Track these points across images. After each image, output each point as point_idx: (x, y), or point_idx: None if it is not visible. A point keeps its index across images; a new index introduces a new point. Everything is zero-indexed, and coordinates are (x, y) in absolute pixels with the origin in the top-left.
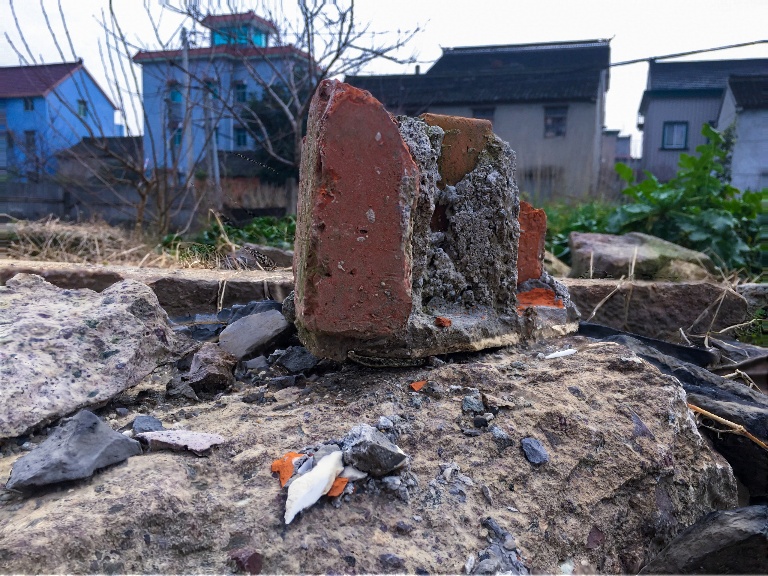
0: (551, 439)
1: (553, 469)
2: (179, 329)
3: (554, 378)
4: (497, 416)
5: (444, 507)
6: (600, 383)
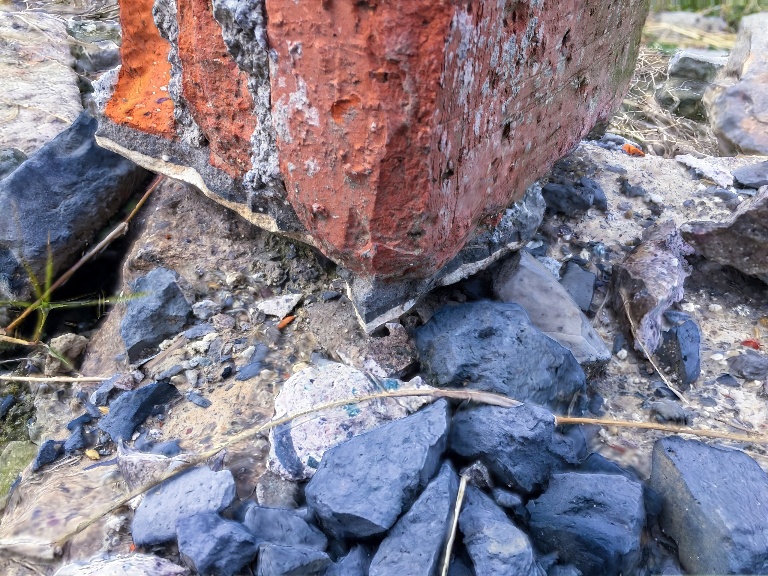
0: None
1: None
2: None
3: None
4: None
5: None
6: None
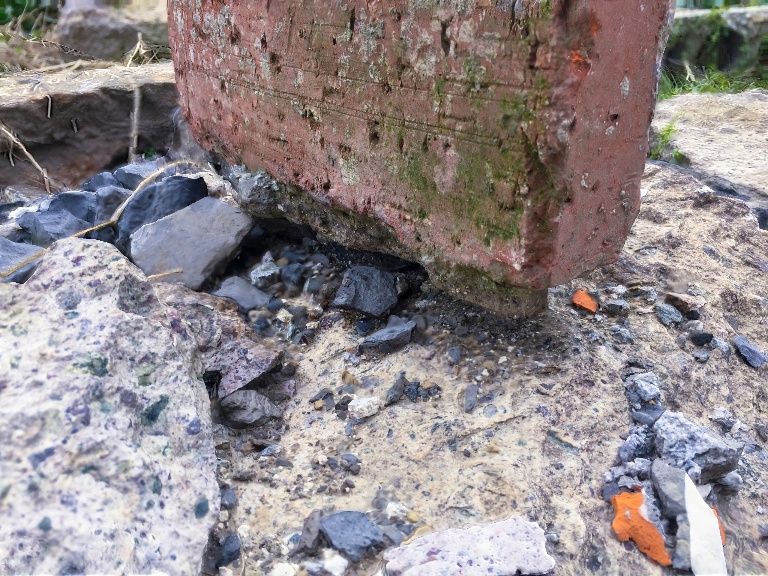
0: (732, 324)
1: (766, 365)
2: None
3: (680, 240)
4: (702, 321)
5: (766, 479)
6: (710, 231)
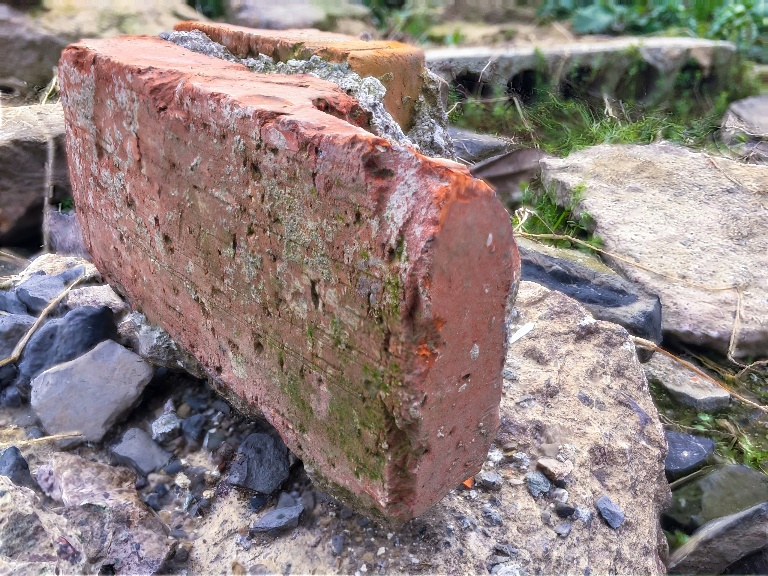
0: (600, 477)
1: (626, 521)
2: None
3: (558, 388)
4: (568, 489)
5: None
6: (588, 371)
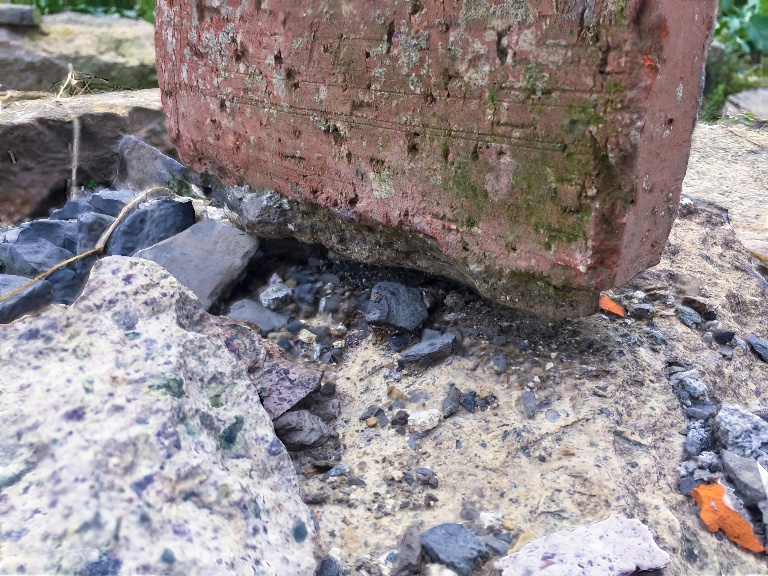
0: None
1: None
2: (35, 286)
3: (678, 248)
4: (719, 321)
5: None
6: (700, 239)
